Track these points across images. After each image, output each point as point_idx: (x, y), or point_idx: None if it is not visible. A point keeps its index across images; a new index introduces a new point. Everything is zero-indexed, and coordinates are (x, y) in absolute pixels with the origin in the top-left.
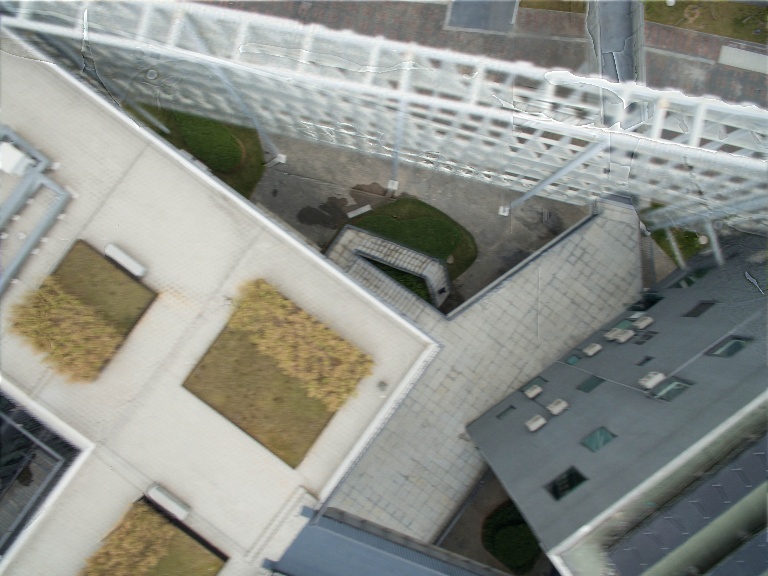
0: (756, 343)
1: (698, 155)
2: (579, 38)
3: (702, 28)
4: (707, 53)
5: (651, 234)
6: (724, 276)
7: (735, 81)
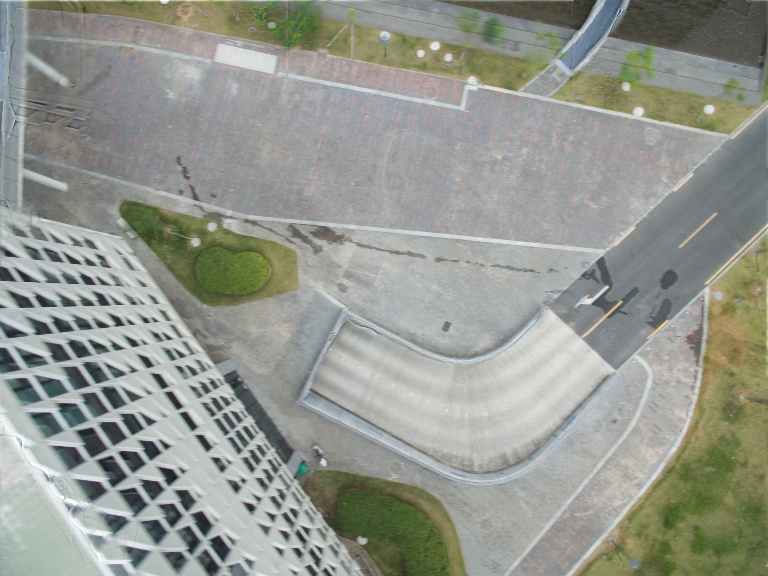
0: (249, 348)
1: (192, 156)
2: (71, 38)
3: (197, 26)
4: (203, 51)
5: (141, 237)
6: (200, 279)
7: (231, 80)
